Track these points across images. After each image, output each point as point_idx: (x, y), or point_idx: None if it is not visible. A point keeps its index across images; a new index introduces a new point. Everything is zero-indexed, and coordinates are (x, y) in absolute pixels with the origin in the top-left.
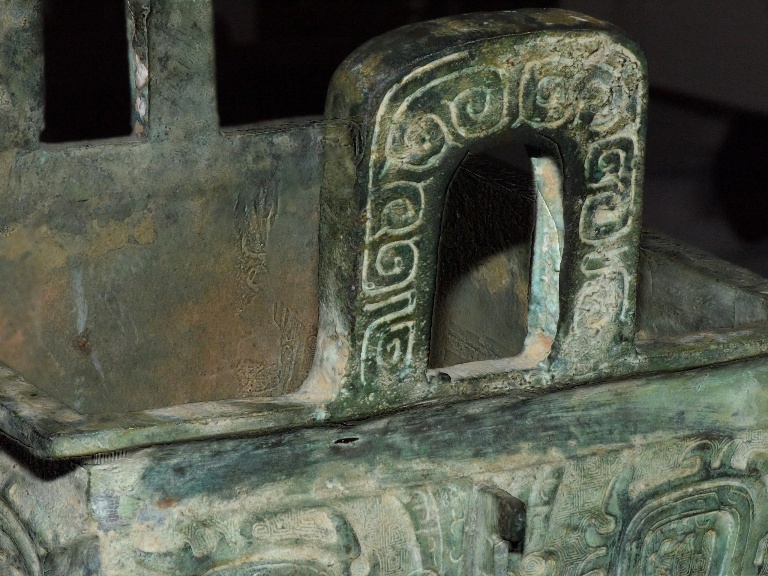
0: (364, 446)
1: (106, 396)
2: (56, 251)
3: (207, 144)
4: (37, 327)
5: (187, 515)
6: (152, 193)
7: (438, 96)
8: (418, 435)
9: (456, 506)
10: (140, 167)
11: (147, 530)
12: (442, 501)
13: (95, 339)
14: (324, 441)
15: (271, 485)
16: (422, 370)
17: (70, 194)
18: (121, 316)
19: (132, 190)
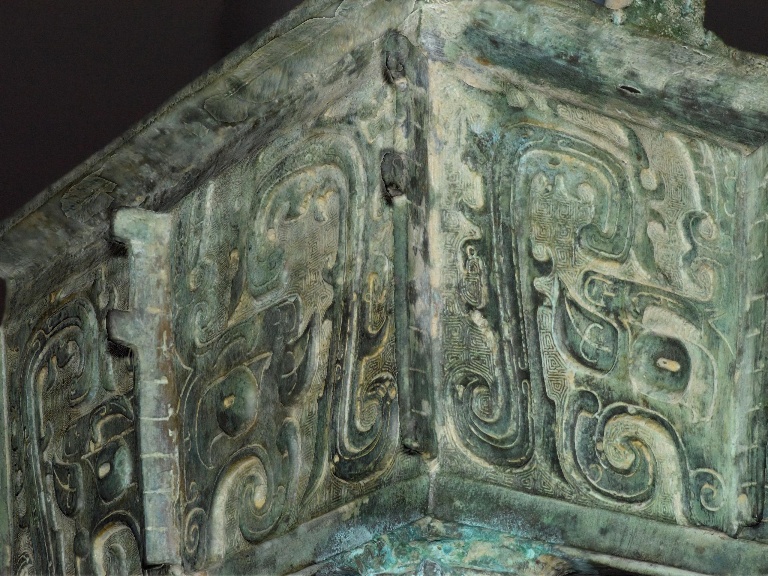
0: (645, 100)
1: None
2: None
3: None
4: None
5: (502, 76)
6: None
7: None
8: (690, 111)
9: (728, 164)
10: None
11: (469, 71)
12: (716, 154)
13: None
14: (612, 81)
15: (570, 91)
16: (700, 16)
17: None
18: None
19: None
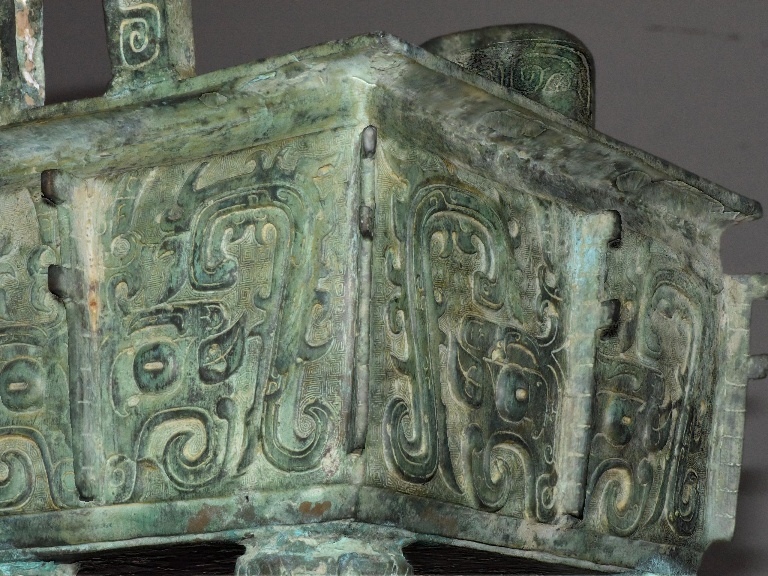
0: None
1: None
2: None
3: None
4: None
5: None
6: None
7: (552, 64)
8: None
9: None
10: None
11: None
12: None
13: None
14: None
15: None
16: None
17: None
18: None
19: None
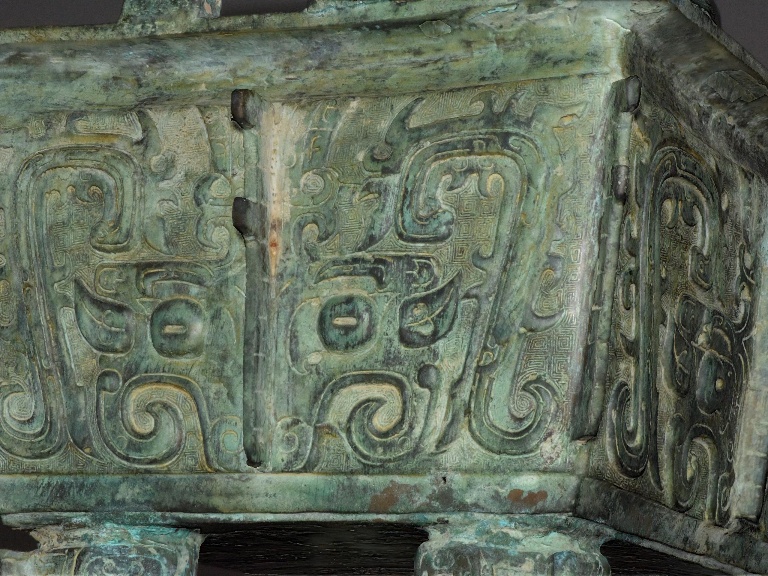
0: None
1: None
2: None
3: None
4: None
5: None
6: None
7: None
8: None
9: None
10: None
11: None
12: None
13: None
14: None
15: None
16: None
17: None
18: None
19: None
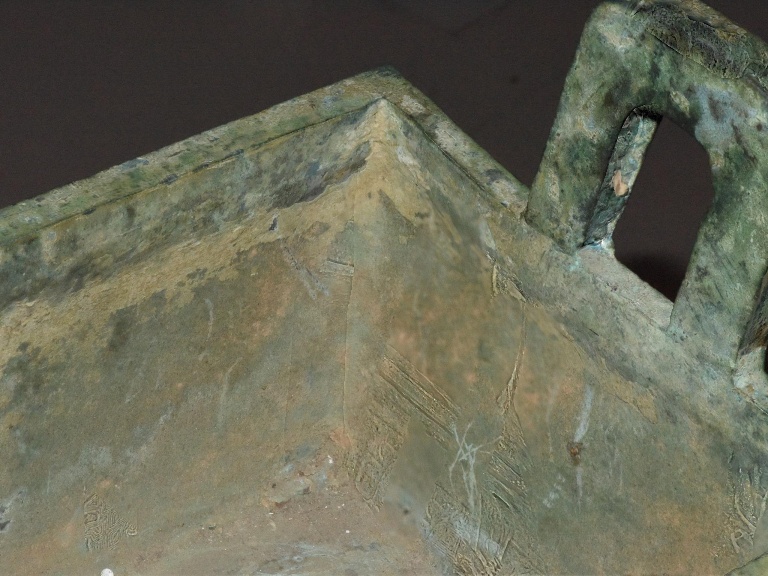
0: None
1: (578, 512)
2: (576, 355)
3: (716, 380)
4: (550, 404)
5: None
6: (654, 379)
7: None
8: None
9: None
10: (650, 347)
11: None
12: None
13: (586, 458)
14: None
15: None
16: None
17: (585, 317)
18: (614, 460)
19: (636, 360)
